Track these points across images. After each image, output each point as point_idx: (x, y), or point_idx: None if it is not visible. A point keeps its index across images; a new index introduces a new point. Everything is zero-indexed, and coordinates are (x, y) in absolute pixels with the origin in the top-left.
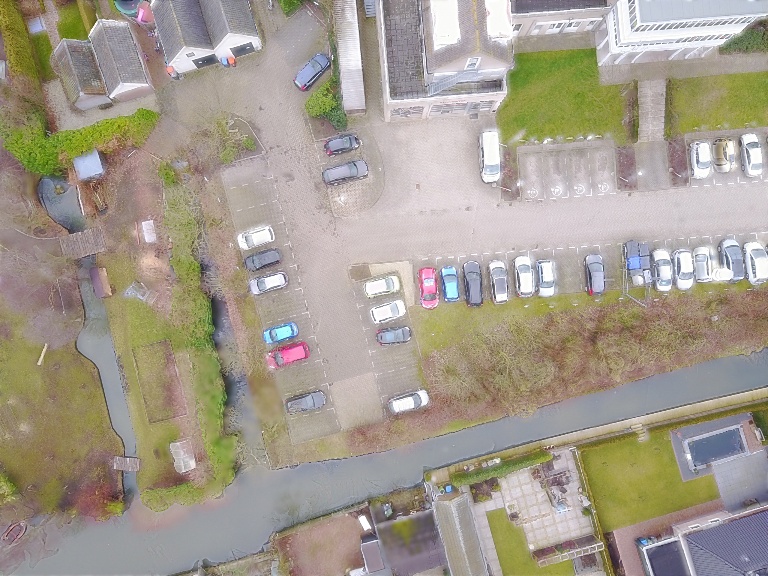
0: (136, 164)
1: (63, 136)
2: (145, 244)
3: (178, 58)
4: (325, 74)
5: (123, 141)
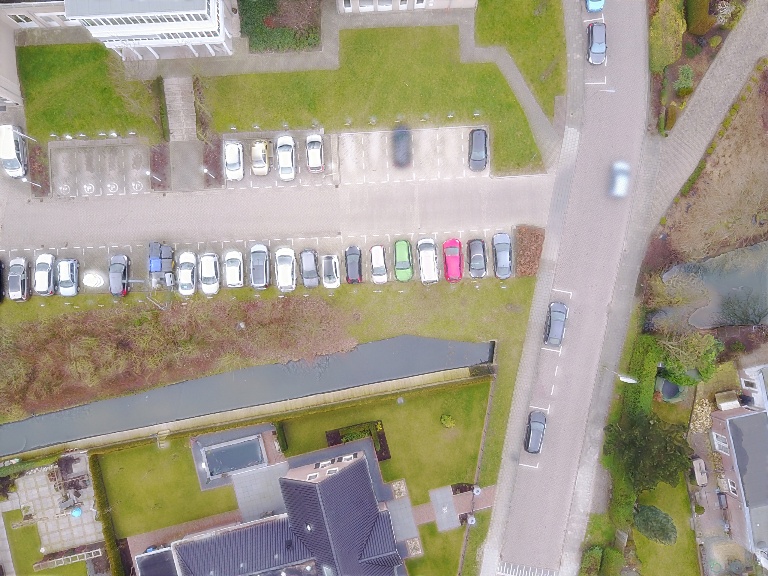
0: None
1: None
2: None
3: None
4: None
5: None
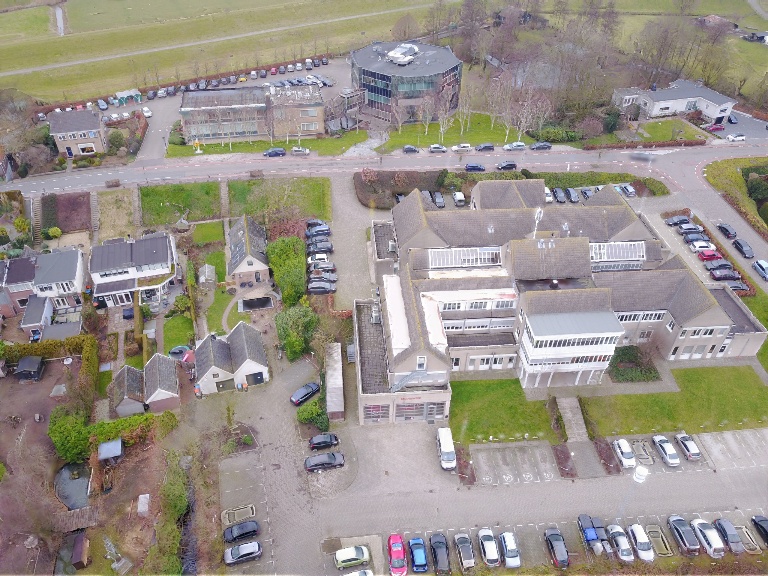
0: (148, 456)
1: (99, 425)
2: (134, 519)
3: (206, 378)
4: (315, 396)
5: (145, 432)
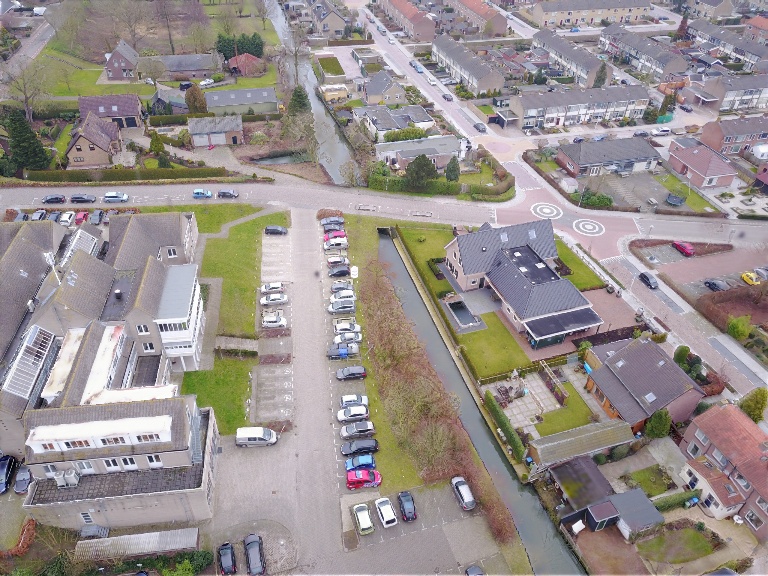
0: None
1: None
2: None
3: None
4: None
5: None
